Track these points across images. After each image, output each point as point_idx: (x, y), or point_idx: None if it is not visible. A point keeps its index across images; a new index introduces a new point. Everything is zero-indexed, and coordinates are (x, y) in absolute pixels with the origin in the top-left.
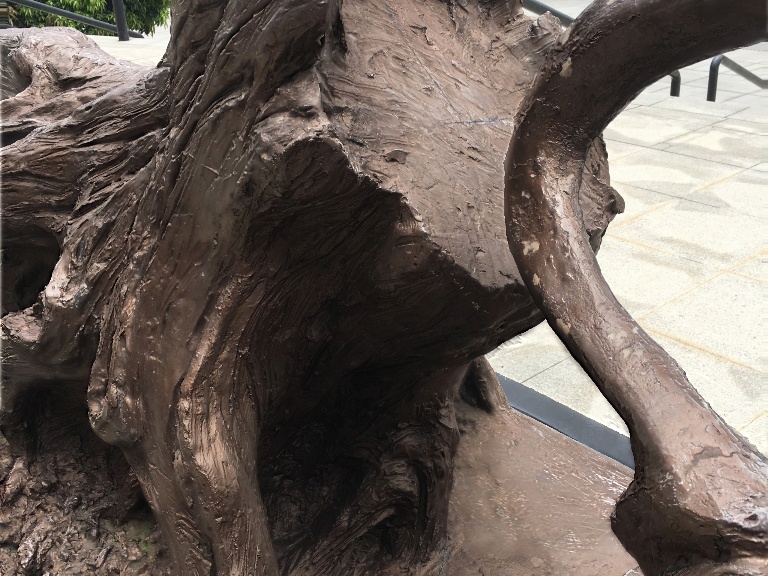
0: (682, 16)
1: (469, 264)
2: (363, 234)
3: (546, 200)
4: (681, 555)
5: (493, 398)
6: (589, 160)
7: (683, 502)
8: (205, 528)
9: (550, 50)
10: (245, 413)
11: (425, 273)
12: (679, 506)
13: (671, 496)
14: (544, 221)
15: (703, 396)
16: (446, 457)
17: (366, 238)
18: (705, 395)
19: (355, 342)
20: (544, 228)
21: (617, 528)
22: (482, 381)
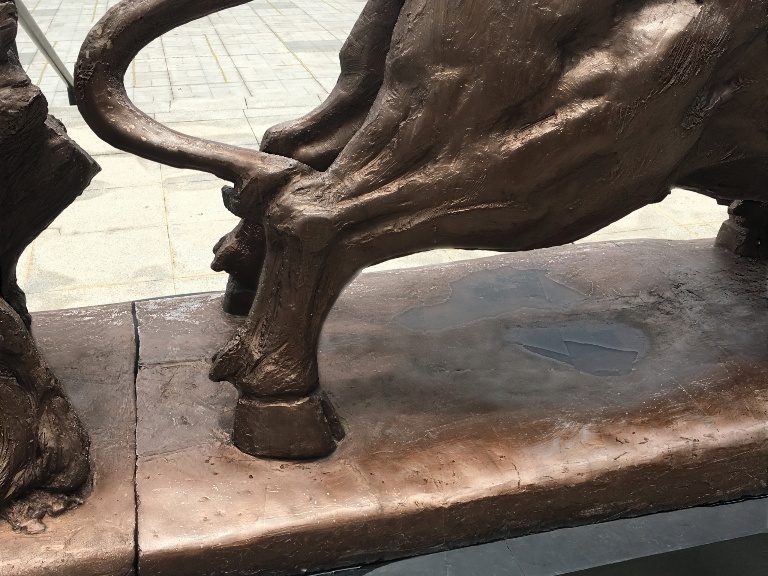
0: (163, 15)
1: None
2: (19, 157)
3: (123, 106)
4: (272, 193)
5: None
6: None
7: (270, 172)
8: (17, 348)
9: (91, 39)
10: None
11: (71, 162)
12: (269, 174)
13: (265, 173)
14: (128, 115)
15: None
16: None
17: (22, 158)
18: None
19: (16, 228)
20: (131, 118)
21: (241, 204)
22: None
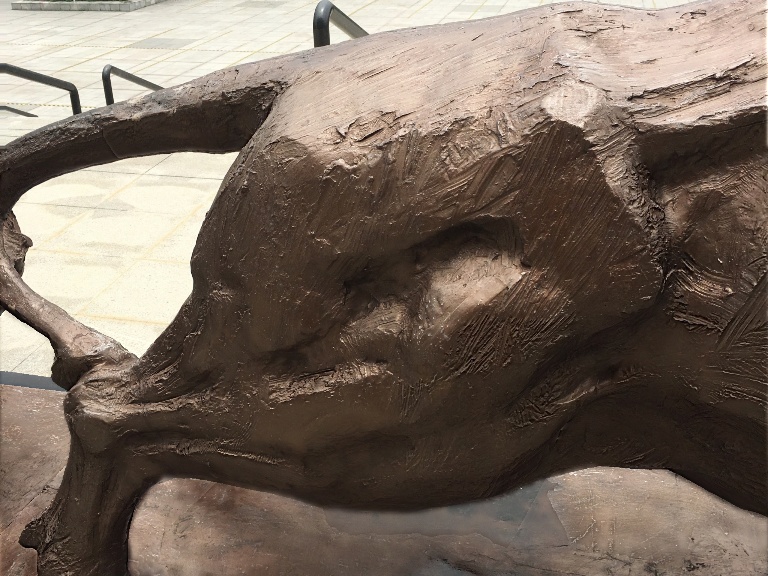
0: (29, 168)
1: None
2: None
3: None
4: (78, 376)
5: None
6: (6, 222)
7: (72, 355)
8: None
9: None
10: None
11: None
12: (71, 357)
13: (68, 355)
14: None
15: (138, 352)
16: None
17: None
18: (140, 351)
19: None
20: None
21: (54, 379)
22: None
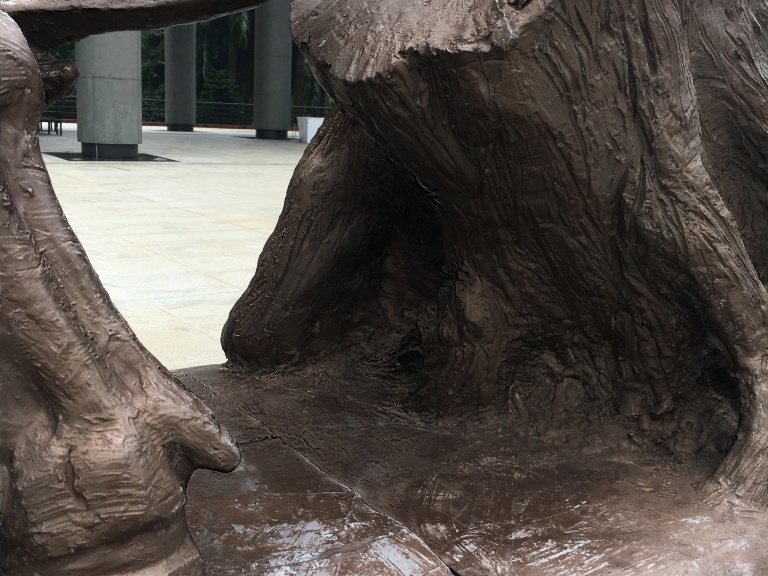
0: None
1: (297, 18)
2: None
3: None
4: None
5: (726, 462)
6: None
7: None
8: None
9: None
10: (341, 155)
11: None
12: None
13: None
14: None
15: None
16: (448, 323)
17: None
18: None
19: None
20: None
21: None
22: (737, 436)
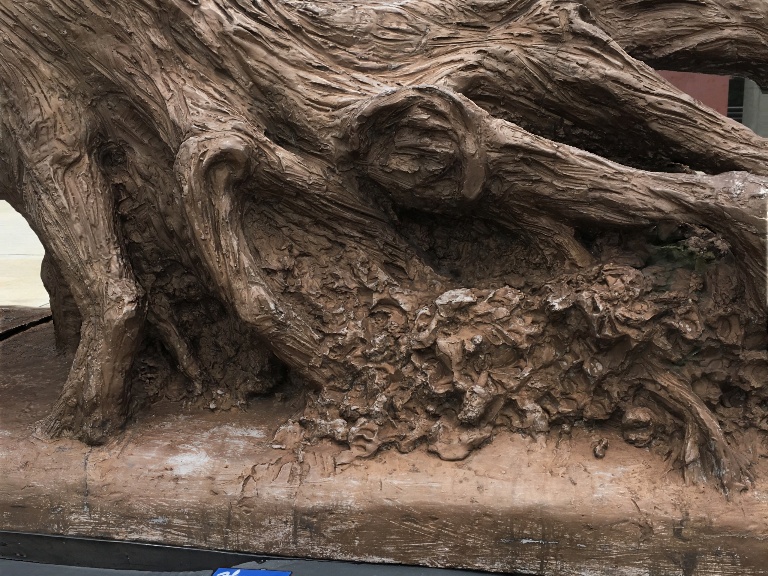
0: None
1: None
2: None
3: None
4: None
5: None
6: None
7: None
8: None
9: None
10: None
11: None
12: None
13: None
14: None
15: None
16: None
17: None
18: None
19: None
20: None
21: None
22: None
